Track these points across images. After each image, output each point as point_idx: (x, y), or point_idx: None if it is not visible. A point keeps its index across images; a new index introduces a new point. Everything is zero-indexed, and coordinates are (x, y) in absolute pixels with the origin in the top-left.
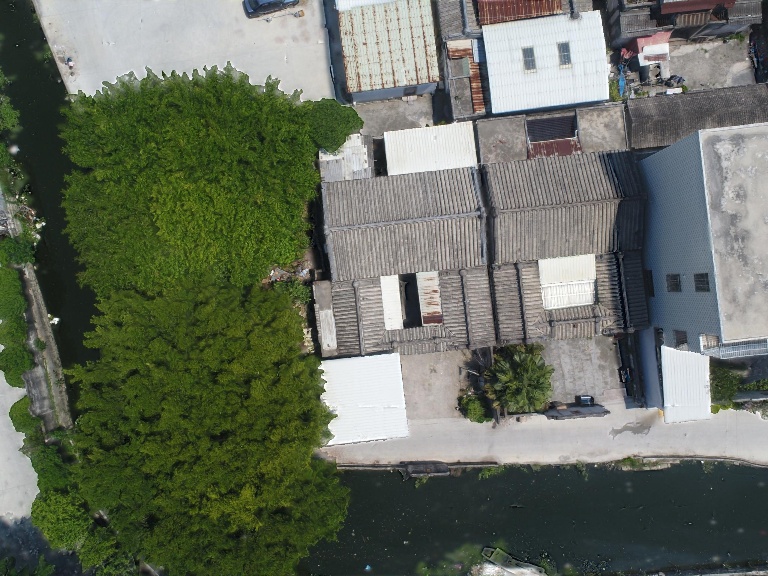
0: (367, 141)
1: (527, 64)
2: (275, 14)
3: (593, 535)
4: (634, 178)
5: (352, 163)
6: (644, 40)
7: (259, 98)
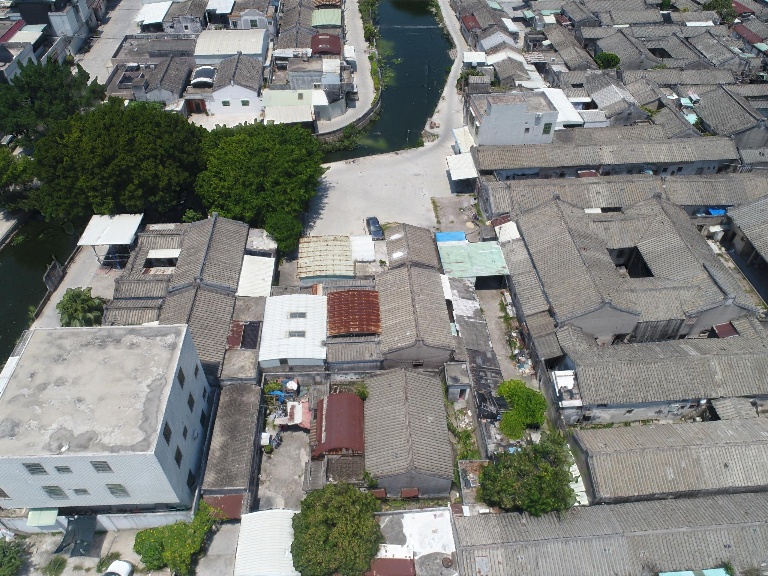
0: (271, 250)
1: (294, 314)
2: (368, 233)
3: None
4: None
5: (259, 242)
6: None
7: None
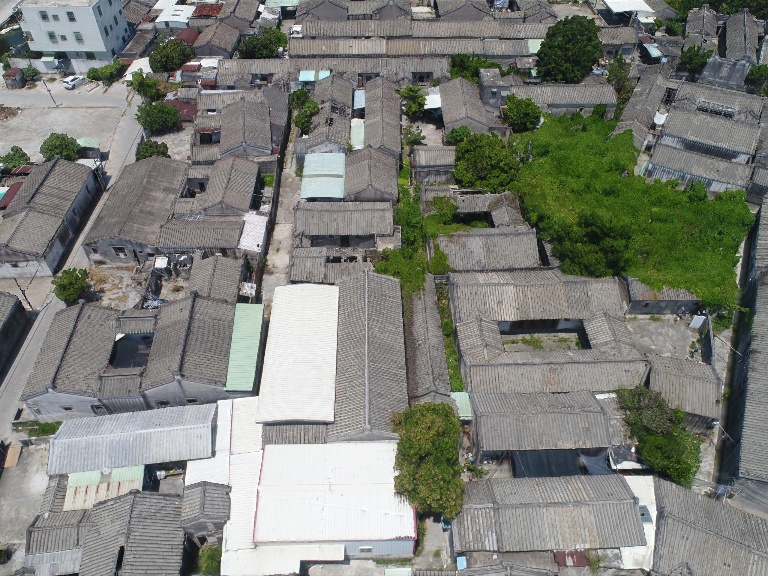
0: None
1: None
2: None
3: (4, 42)
4: None
5: None
6: None
7: None
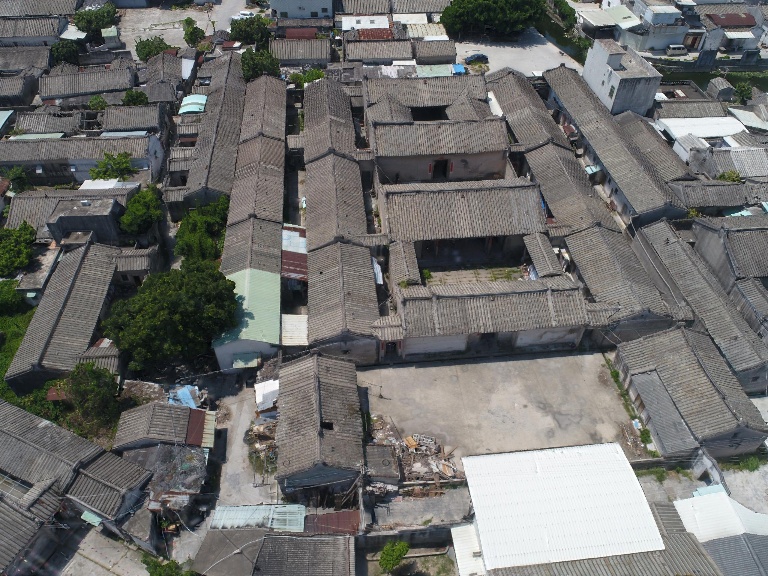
0: (434, 22)
1: None
2: None
3: None
4: (337, 4)
5: None
6: None
7: (474, 1)
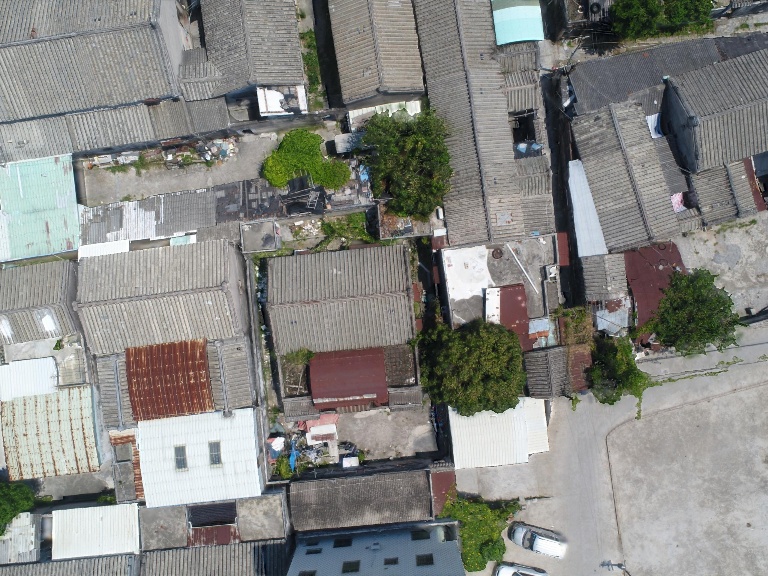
0: (36, 520)
1: (179, 463)
2: None
3: None
4: None
5: (19, 544)
6: (312, 420)
7: None
